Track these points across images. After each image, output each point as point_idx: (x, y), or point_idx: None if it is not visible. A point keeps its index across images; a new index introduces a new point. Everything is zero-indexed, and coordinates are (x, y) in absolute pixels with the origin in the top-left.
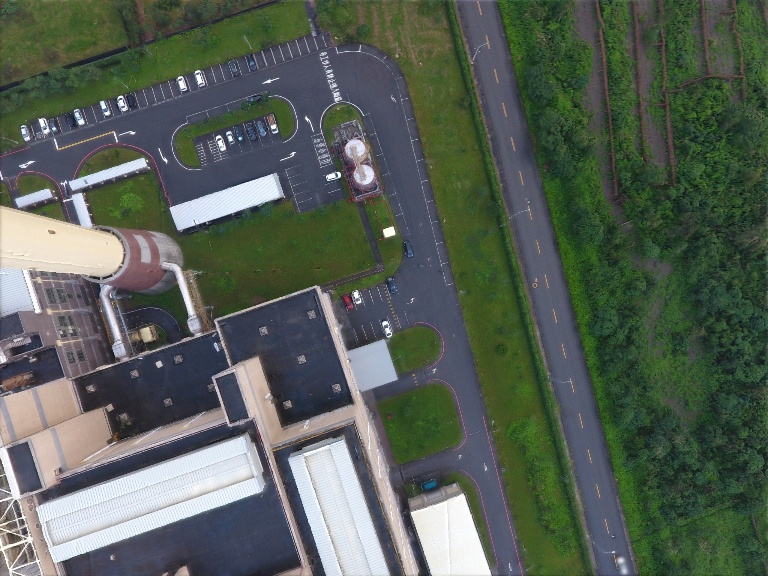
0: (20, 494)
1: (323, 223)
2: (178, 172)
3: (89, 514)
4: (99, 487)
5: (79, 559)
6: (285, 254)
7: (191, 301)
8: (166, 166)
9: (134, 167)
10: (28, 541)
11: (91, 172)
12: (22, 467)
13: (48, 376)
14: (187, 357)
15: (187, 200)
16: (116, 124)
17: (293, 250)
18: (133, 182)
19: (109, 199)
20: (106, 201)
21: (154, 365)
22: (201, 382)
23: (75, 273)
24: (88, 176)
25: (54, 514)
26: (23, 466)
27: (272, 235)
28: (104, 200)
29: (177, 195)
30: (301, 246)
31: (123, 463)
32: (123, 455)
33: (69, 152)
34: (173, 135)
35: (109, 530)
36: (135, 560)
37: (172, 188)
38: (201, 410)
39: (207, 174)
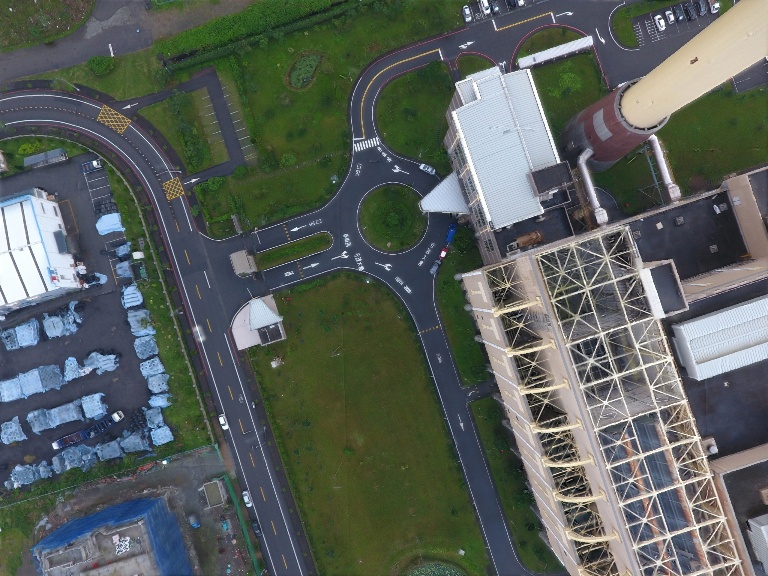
0: (664, 313)
1: (762, 103)
2: (615, 52)
3: (728, 335)
4: (741, 308)
5: (694, 385)
6: (724, 134)
7: (667, 170)
8: (603, 46)
9: (581, 45)
10: (668, 360)
11: (531, 52)
12: (662, 288)
13: (551, 236)
14: (687, 219)
15: (624, 80)
16: (553, 5)
17: (732, 130)
18: (572, 62)
19: (548, 79)
20: (545, 81)
21: (655, 226)
22: (701, 244)
23: (664, 112)
24: (537, 54)
25: (700, 333)
26: (663, 287)
27: (711, 115)
28: (543, 80)
29: (615, 75)
30: (740, 126)
31: (737, 292)
32: (743, 282)
33: (507, 33)
34: (610, 16)
35: (753, 349)
36: (749, 387)
37: (609, 68)
38: (702, 271)
39: (644, 54)
